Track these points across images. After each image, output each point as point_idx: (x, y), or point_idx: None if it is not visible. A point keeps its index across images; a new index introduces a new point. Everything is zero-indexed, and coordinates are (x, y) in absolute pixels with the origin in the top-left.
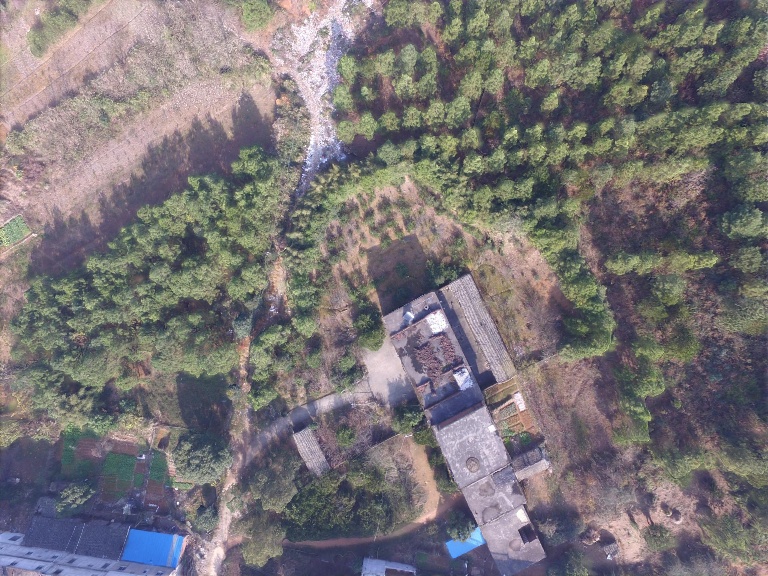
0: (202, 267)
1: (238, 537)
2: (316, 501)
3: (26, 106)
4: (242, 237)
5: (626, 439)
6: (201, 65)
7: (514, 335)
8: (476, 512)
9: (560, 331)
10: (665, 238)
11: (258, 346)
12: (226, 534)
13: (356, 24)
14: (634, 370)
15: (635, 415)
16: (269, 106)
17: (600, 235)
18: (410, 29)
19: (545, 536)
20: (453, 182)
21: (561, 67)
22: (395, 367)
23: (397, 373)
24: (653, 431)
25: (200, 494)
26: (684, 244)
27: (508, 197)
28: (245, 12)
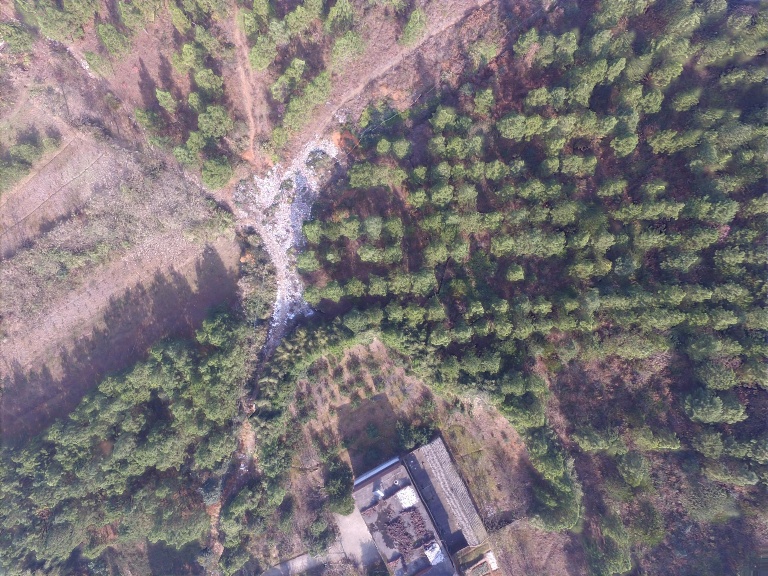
0: (167, 443)
1: None
2: None
3: None
4: (208, 410)
5: None
6: (162, 218)
7: (485, 495)
8: None
9: (530, 493)
10: (630, 413)
11: (227, 520)
12: None
13: (321, 175)
14: (602, 546)
15: None
16: (234, 259)
17: (567, 403)
18: None
19: None
20: (421, 352)
21: (526, 243)
22: None
23: (370, 534)
24: None
25: None
26: (649, 416)
27: (476, 371)
28: (205, 178)
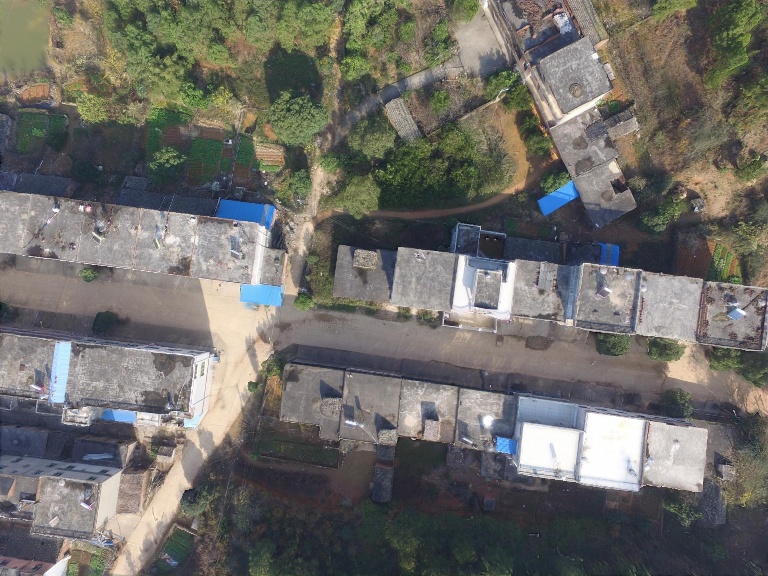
0: None
1: (327, 211)
2: (410, 161)
3: None
4: None
5: (722, 70)
6: None
7: (604, 7)
8: (569, 164)
9: None
10: None
11: (357, 0)
12: (315, 210)
13: None
14: None
15: (733, 41)
16: None
17: None
18: None
19: (635, 191)
20: None
21: None
22: (486, 41)
23: (488, 47)
24: (745, 74)
25: (288, 174)
26: None
27: None
28: None
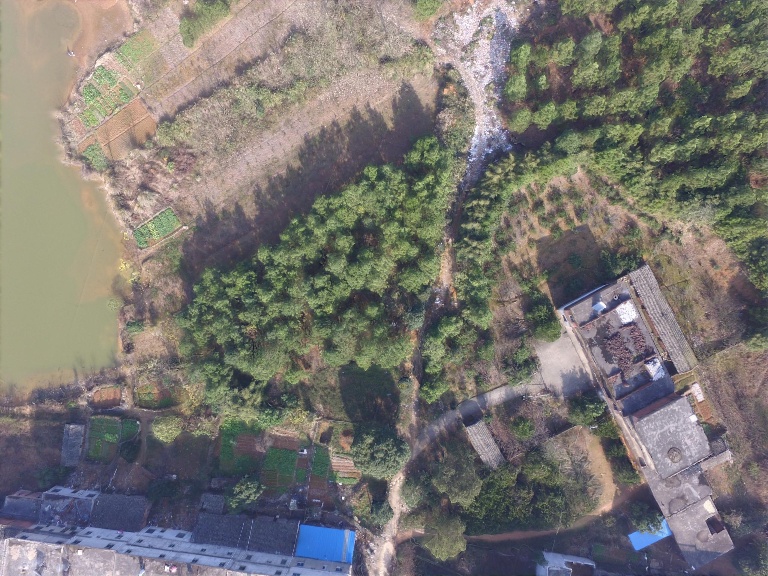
0: (383, 258)
1: (408, 532)
2: (496, 494)
3: (175, 97)
4: (422, 228)
5: None
6: (361, 55)
7: (691, 325)
8: (662, 503)
9: (741, 321)
10: None
11: (439, 338)
12: (395, 529)
13: (520, 13)
14: None
15: None
16: (430, 96)
17: None
18: (578, 18)
19: (730, 527)
20: (638, 171)
21: (754, 55)
22: (569, 358)
23: (571, 364)
24: None
25: (366, 489)
26: None
27: (698, 186)
28: (422, 0)
